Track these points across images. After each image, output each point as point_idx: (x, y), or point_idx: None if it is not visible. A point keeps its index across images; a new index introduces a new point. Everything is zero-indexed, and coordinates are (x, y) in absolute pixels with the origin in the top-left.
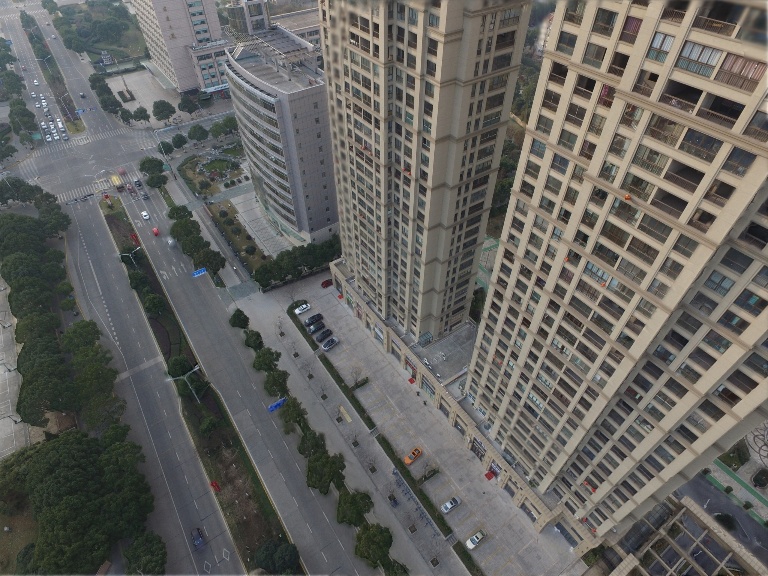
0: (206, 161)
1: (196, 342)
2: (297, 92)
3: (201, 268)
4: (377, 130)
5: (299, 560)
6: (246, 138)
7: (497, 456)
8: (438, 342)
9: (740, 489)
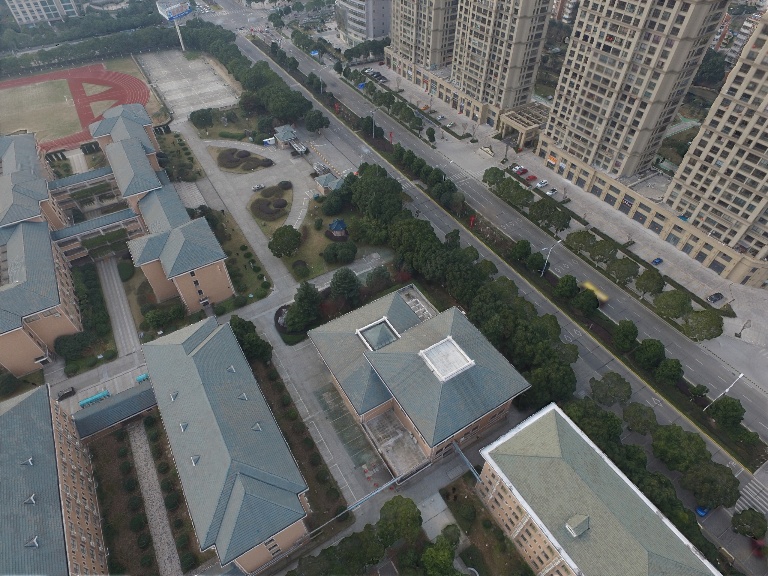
0: (303, 22)
1: None
2: None
3: (315, 50)
4: None
5: None
6: None
7: (462, 93)
8: (439, 70)
9: None
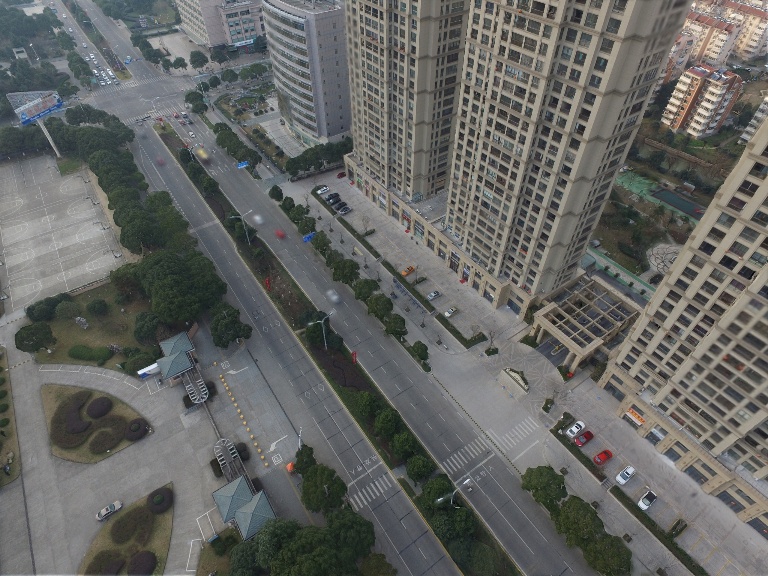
0: (237, 98)
1: (243, 212)
2: (321, 13)
3: (244, 161)
4: (381, 21)
5: (329, 322)
6: (277, 62)
7: (466, 258)
8: (427, 200)
9: (640, 285)
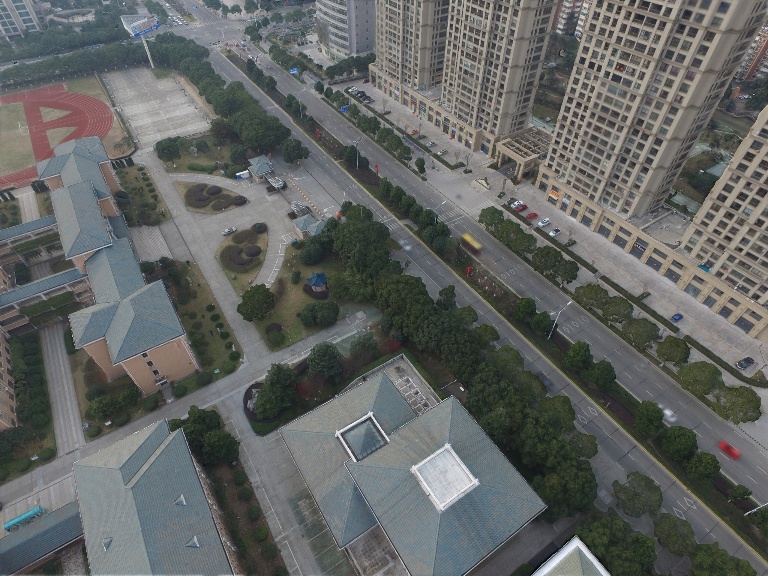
0: (283, 35)
1: None
2: None
3: (295, 68)
4: None
5: None
6: None
7: (454, 118)
8: (428, 90)
9: None
